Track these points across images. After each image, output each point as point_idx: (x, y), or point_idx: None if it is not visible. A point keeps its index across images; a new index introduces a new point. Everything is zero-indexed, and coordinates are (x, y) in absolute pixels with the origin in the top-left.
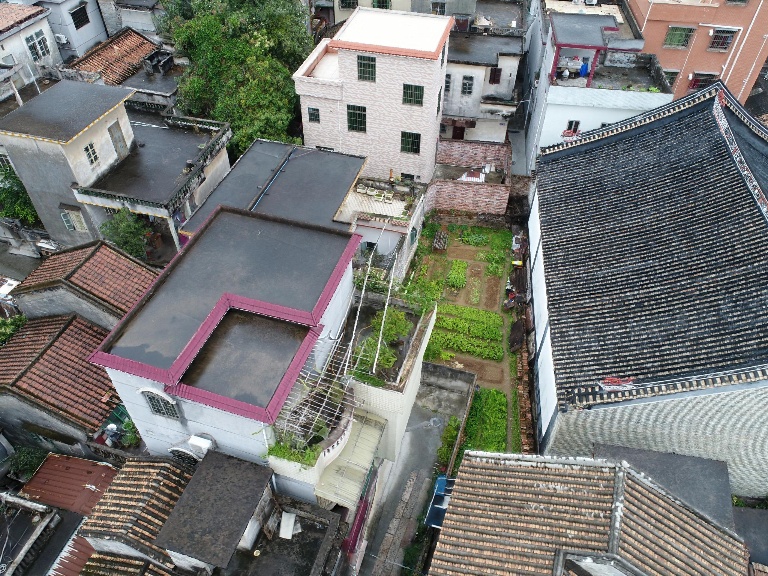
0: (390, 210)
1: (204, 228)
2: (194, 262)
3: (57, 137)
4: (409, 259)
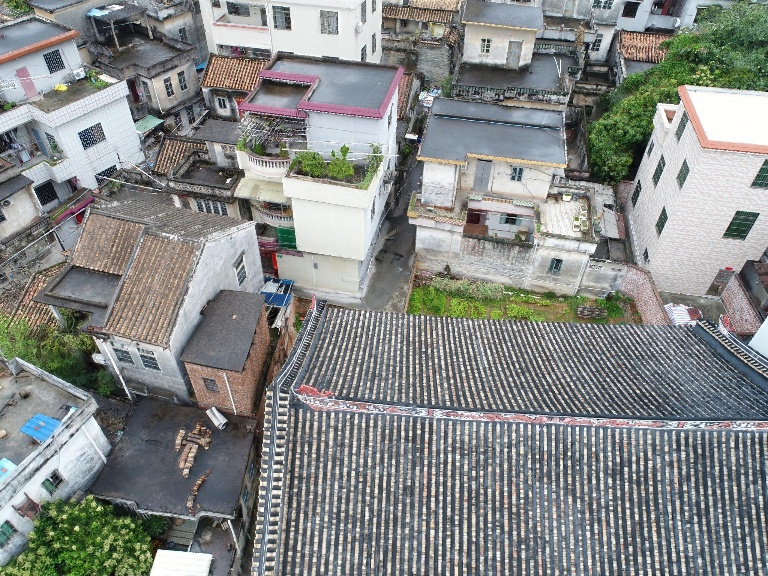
0: (562, 231)
1: (378, 65)
2: (349, 68)
3: (466, 17)
4: (547, 285)
